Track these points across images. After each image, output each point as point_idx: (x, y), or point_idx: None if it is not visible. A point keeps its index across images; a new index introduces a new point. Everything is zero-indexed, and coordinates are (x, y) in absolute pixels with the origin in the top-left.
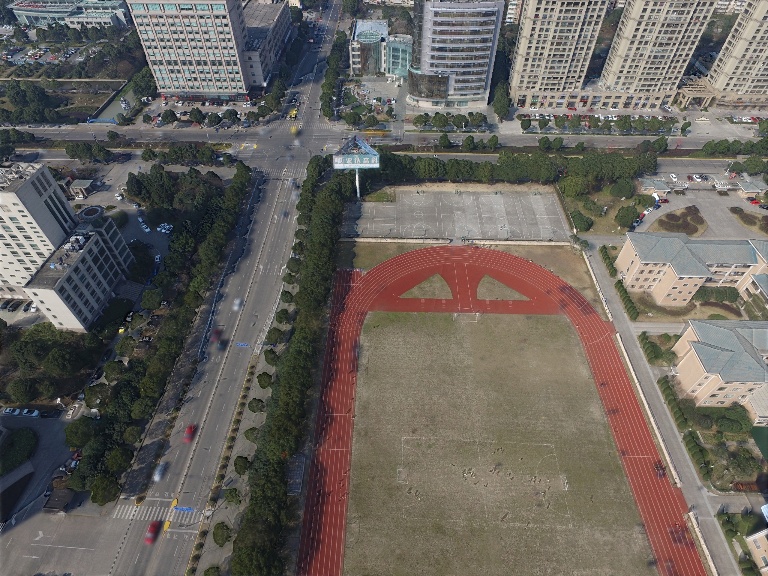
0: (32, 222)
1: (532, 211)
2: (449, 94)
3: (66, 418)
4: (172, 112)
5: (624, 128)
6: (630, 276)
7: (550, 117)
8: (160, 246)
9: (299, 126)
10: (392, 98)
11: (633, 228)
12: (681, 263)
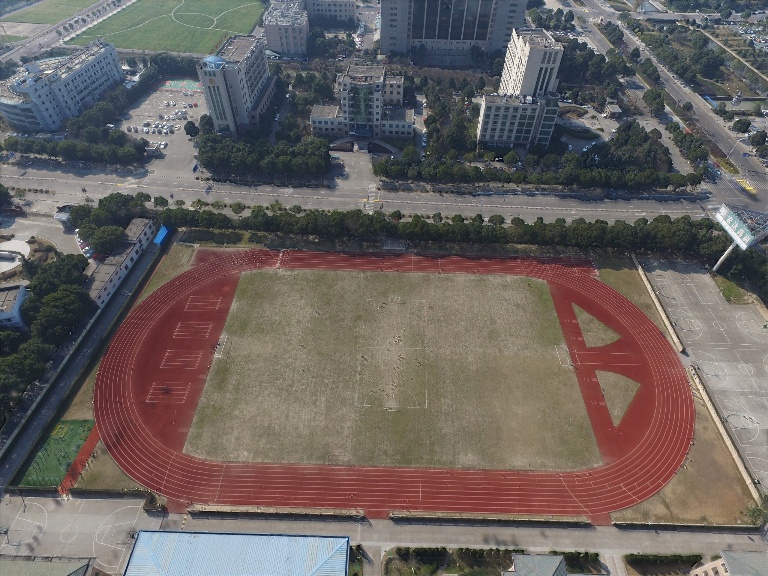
0: (524, 72)
1: None
2: None
3: (423, 154)
4: (748, 123)
5: None
6: None
7: None
8: None
9: None
10: None
11: None
12: None
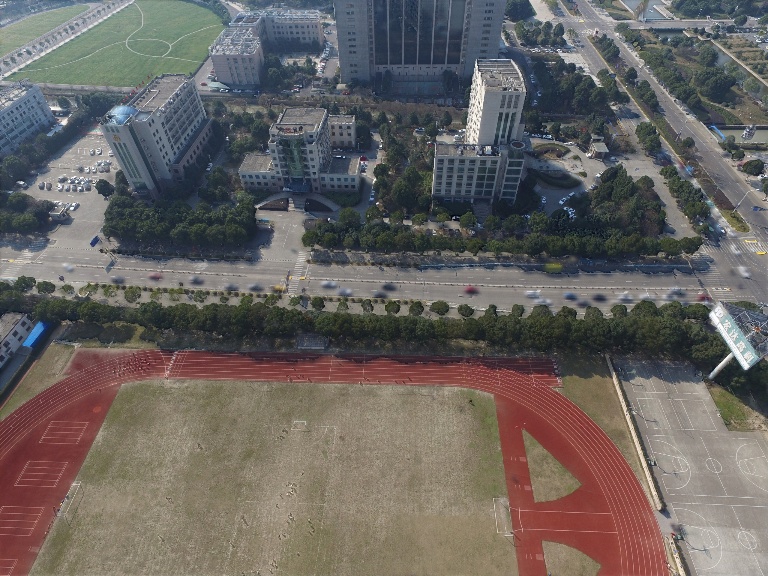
0: None
1: None
2: None
3: None
4: (760, 165)
5: None
6: None
7: None
8: None
9: None
10: None
11: None
12: None
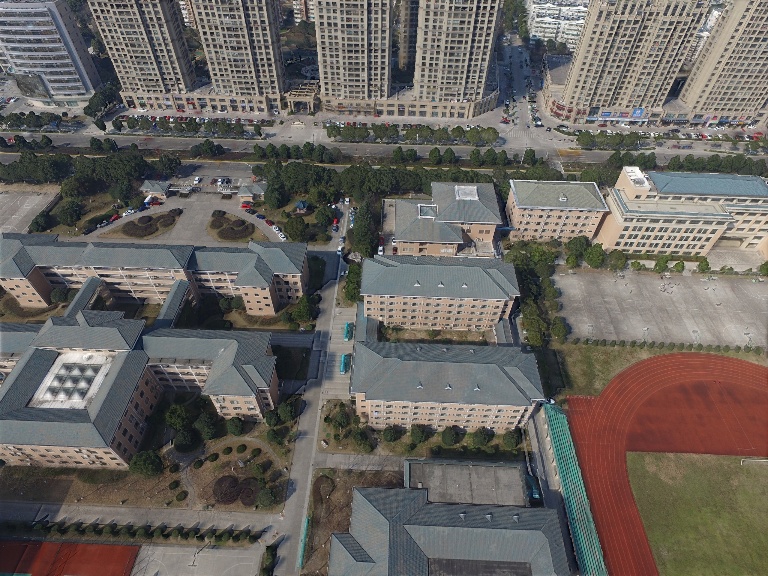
0: None
1: (14, 211)
2: (53, 94)
3: None
4: None
5: (189, 130)
6: None
7: None
8: None
9: None
10: None
11: (89, 230)
12: (2, 264)
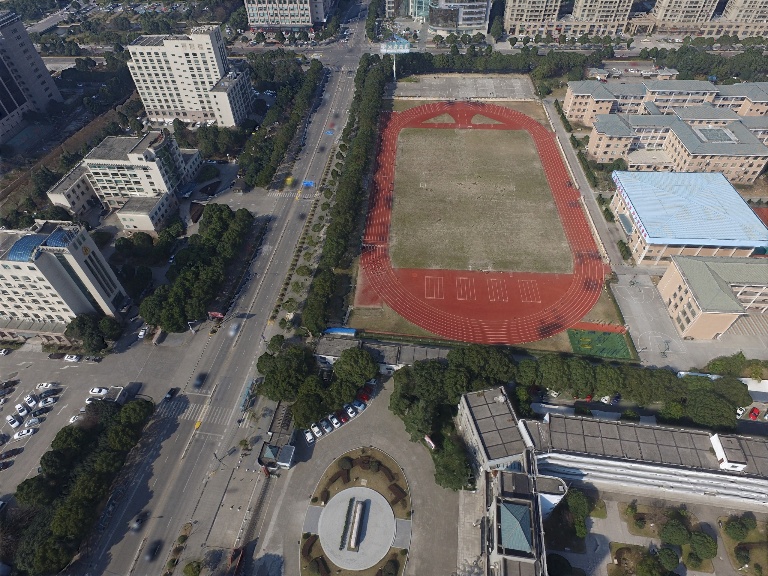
0: (213, 57)
1: (512, 86)
2: (459, 24)
3: (232, 163)
4: (263, 34)
5: (584, 42)
6: (569, 109)
7: (533, 39)
8: (268, 101)
9: (351, 45)
10: (417, 30)
11: None
12: (597, 93)
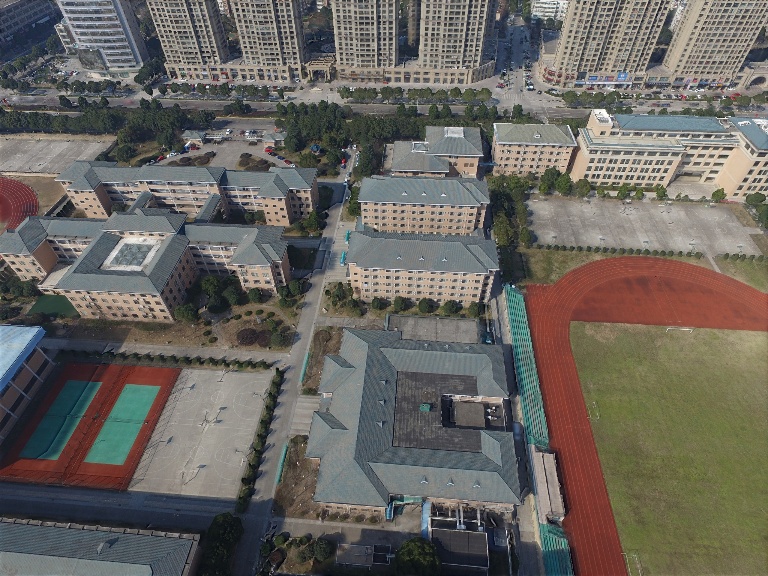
0: None
1: (80, 154)
2: (109, 66)
3: None
4: None
5: (222, 93)
6: None
7: None
8: None
9: None
10: (75, 71)
11: (140, 166)
12: None
